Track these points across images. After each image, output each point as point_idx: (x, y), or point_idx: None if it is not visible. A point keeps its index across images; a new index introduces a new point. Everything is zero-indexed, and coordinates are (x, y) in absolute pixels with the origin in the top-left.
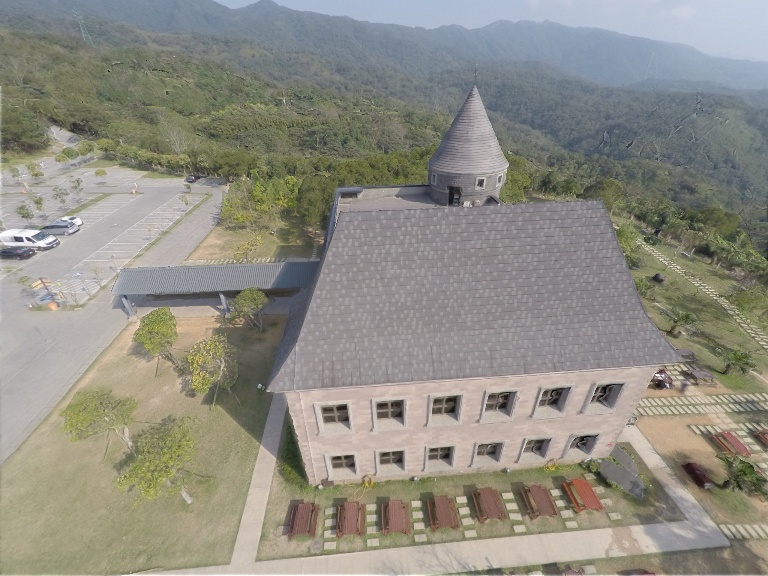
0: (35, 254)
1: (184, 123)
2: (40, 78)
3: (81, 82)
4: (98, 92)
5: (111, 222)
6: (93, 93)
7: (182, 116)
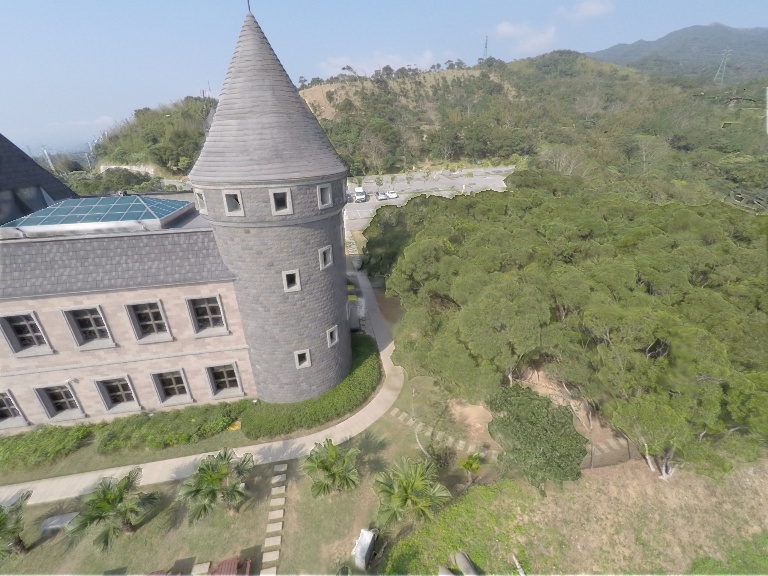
0: (350, 202)
1: (668, 156)
2: (603, 112)
3: (633, 114)
4: (643, 124)
5: (403, 202)
6: (635, 125)
7: (672, 148)
